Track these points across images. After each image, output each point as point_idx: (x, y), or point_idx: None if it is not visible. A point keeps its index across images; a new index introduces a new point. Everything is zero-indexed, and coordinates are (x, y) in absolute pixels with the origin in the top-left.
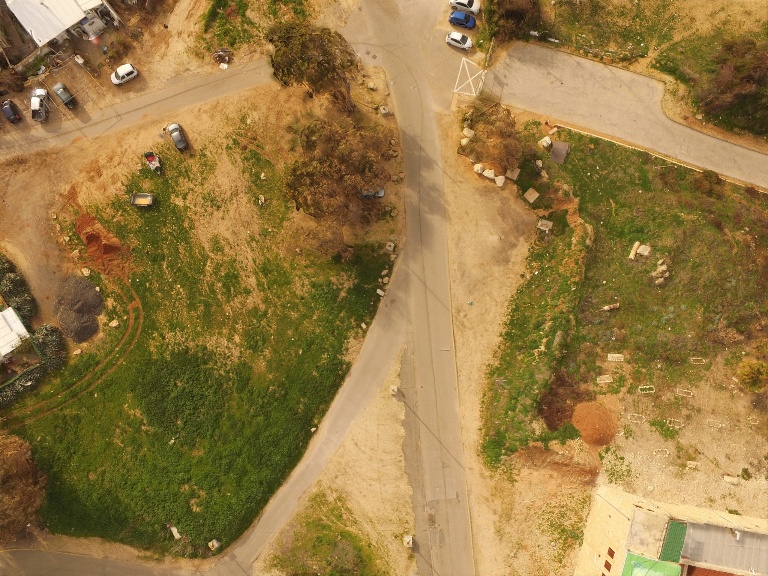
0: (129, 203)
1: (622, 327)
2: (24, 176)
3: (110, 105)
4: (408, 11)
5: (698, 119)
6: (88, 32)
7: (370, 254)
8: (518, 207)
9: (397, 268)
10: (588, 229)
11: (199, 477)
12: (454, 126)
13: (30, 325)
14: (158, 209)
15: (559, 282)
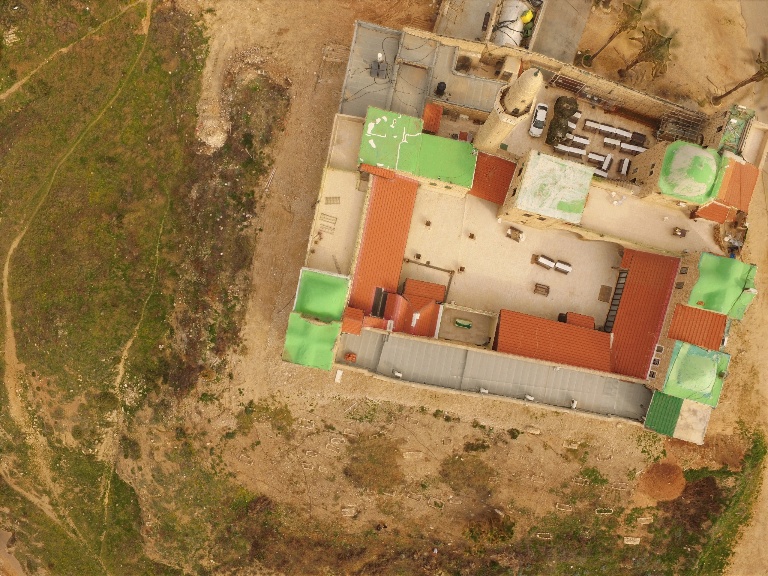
0: None
1: (622, 569)
2: None
3: None
4: None
5: None
6: None
7: None
8: None
9: None
10: None
11: None
12: None
13: None
14: None
15: None
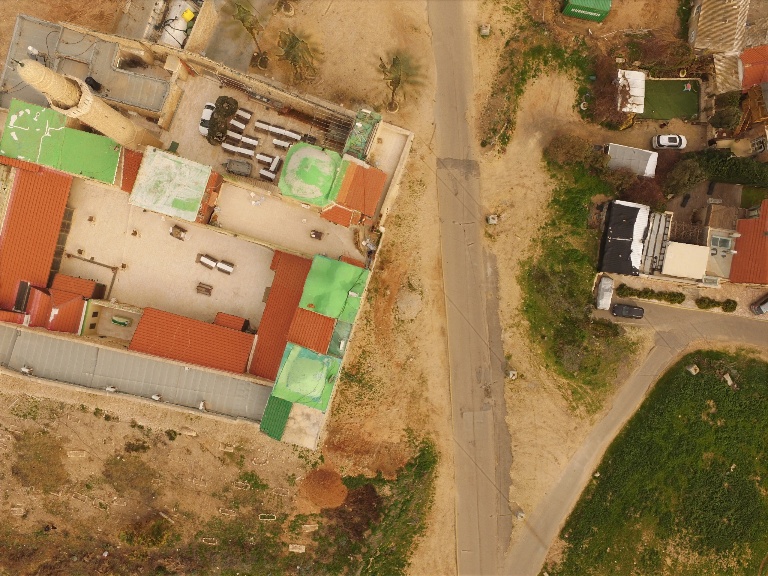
0: None
1: None
2: None
3: None
4: None
5: None
6: None
7: None
8: None
9: None
10: None
11: (708, 433)
12: None
13: None
14: None
15: None
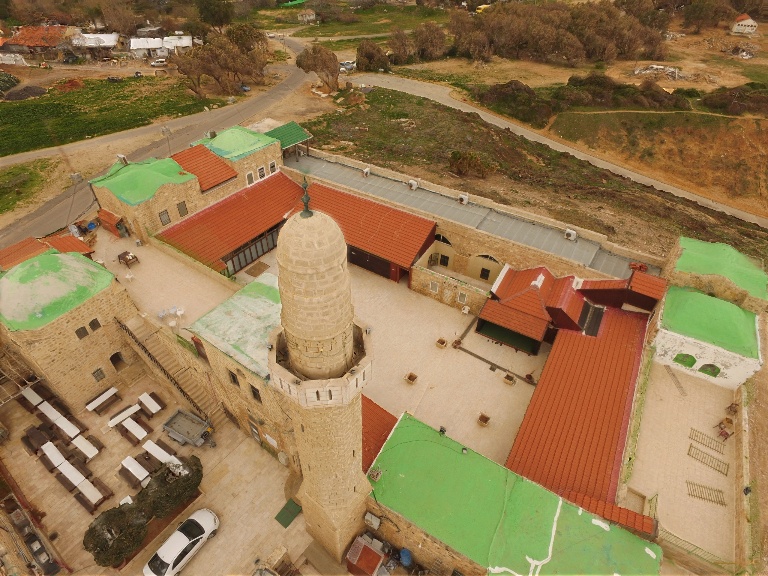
0: None
1: None
2: None
3: None
4: None
5: (475, 103)
6: None
7: None
8: (329, 104)
9: (228, 106)
10: (365, 104)
11: None
12: None
13: None
14: None
15: None
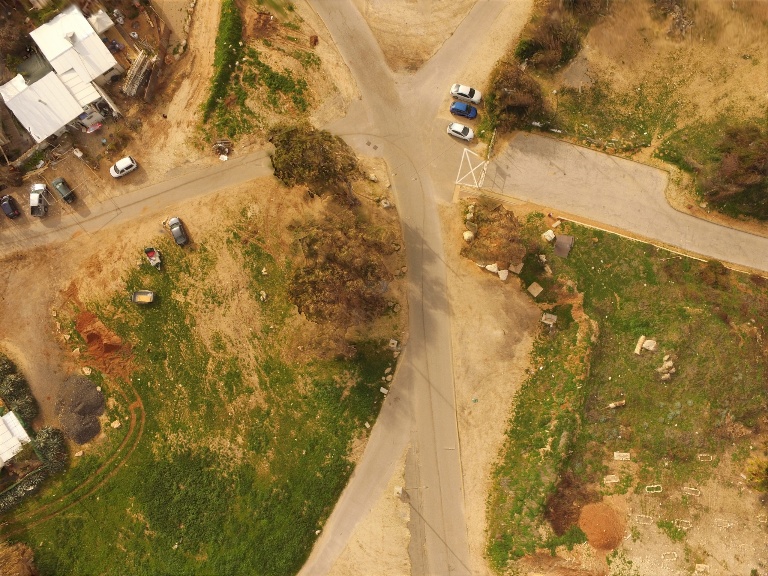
0: (130, 300)
1: (628, 424)
2: (24, 273)
3: (109, 198)
4: (409, 100)
5: (702, 207)
6: (87, 125)
7: (373, 351)
8: (522, 301)
9: (400, 365)
10: (593, 325)
11: None
12: (456, 218)
13: (31, 427)
14: (159, 306)
15: (564, 379)
